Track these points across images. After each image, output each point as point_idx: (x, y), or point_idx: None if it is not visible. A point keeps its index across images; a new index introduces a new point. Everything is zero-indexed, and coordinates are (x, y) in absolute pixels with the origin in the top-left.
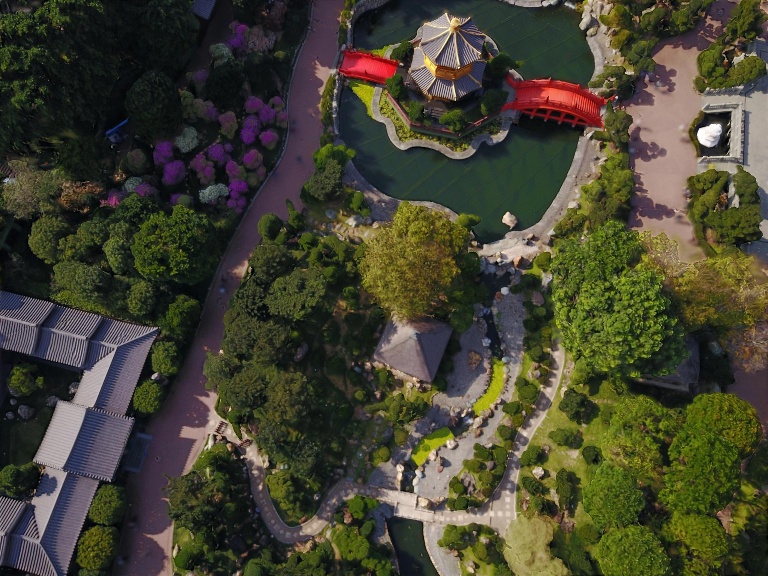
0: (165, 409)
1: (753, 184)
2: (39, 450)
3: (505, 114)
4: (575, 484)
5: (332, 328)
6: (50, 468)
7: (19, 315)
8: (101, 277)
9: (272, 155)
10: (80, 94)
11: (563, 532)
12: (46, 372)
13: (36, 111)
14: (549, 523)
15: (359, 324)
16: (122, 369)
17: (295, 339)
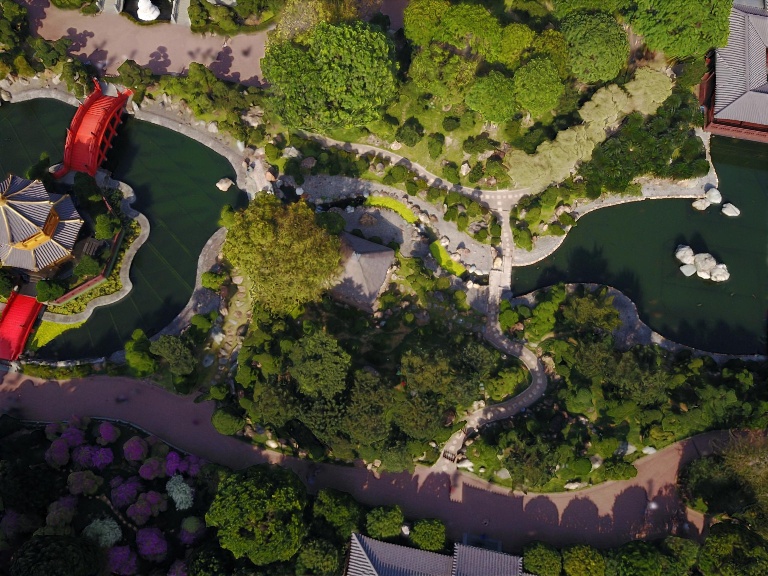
0: None
1: None
2: None
3: (100, 182)
4: None
5: (346, 343)
6: None
7: None
8: None
9: (126, 433)
10: None
11: None
12: None
13: None
14: (512, 152)
15: None
16: (403, 568)
17: None
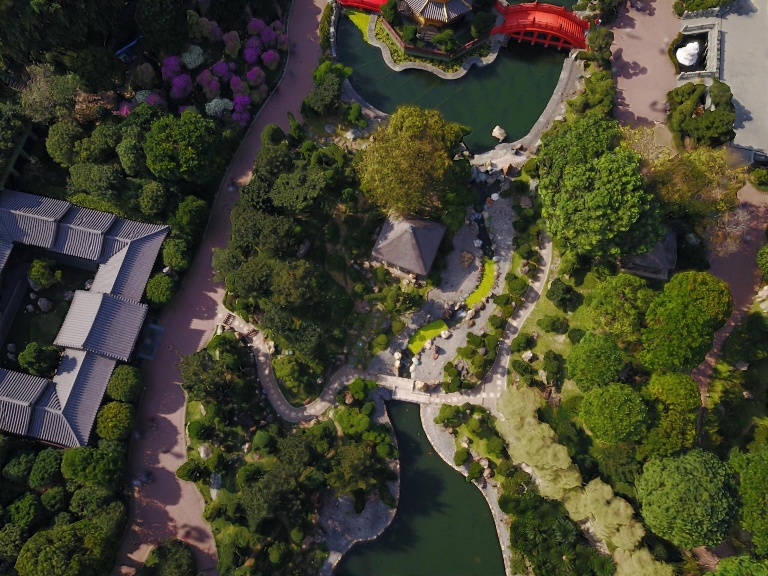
0: (176, 304)
1: (727, 92)
2: (59, 334)
3: (494, 37)
4: (562, 364)
5: (332, 226)
6: (70, 350)
7: (38, 212)
8: (115, 175)
9: (273, 75)
10: (94, 2)
11: (551, 407)
12: (63, 269)
13: (53, 15)
14: (537, 392)
15: (358, 226)
16: (136, 262)
17: (298, 234)
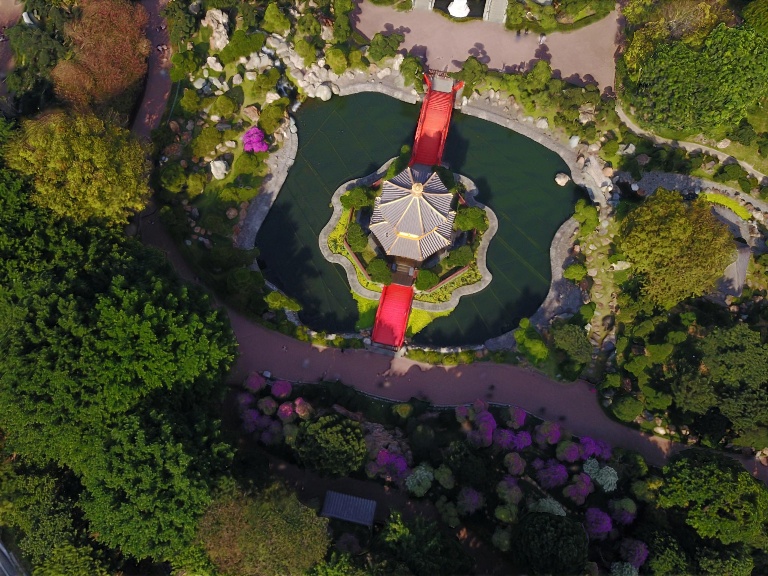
0: None
1: None
2: None
3: None
4: None
5: None
6: None
7: None
8: None
9: None
10: None
11: None
12: None
13: None
14: None
15: None
16: None
17: None
